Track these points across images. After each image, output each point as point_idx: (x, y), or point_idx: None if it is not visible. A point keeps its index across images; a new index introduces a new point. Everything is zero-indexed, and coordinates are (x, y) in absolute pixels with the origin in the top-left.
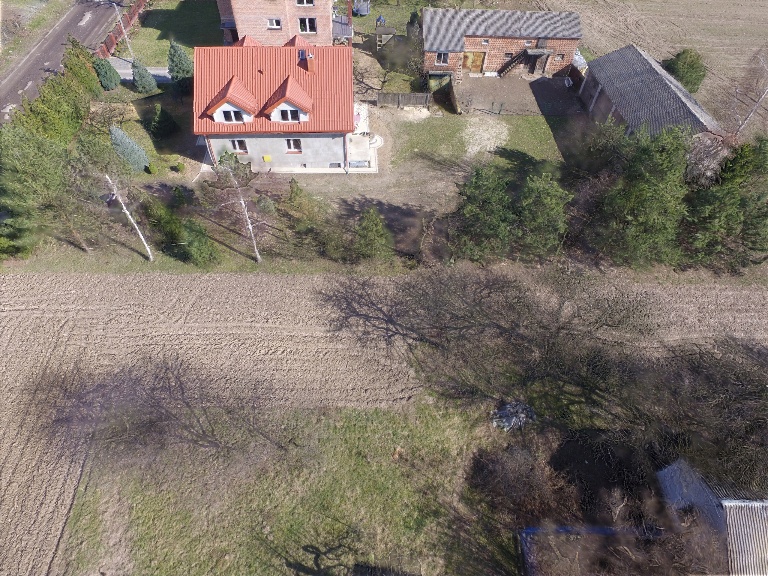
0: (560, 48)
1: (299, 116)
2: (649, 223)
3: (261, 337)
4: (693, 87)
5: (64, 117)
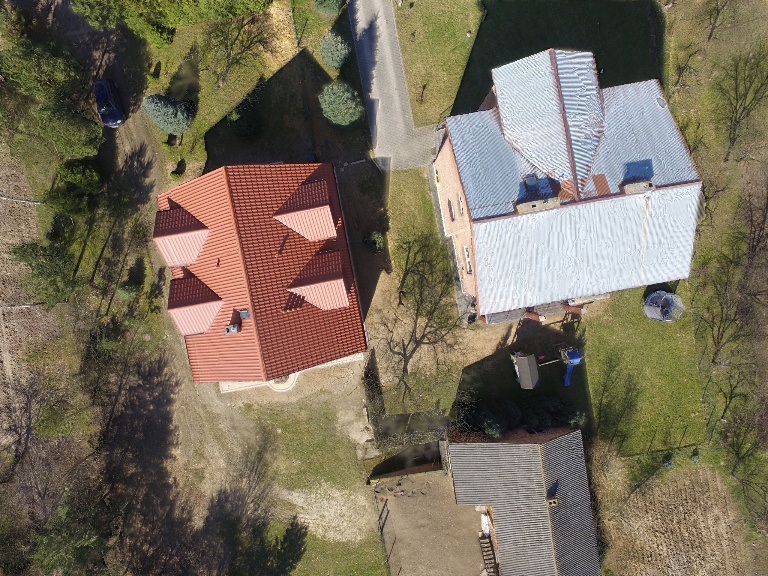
0: None
1: None
2: None
3: None
4: None
5: (204, 6)
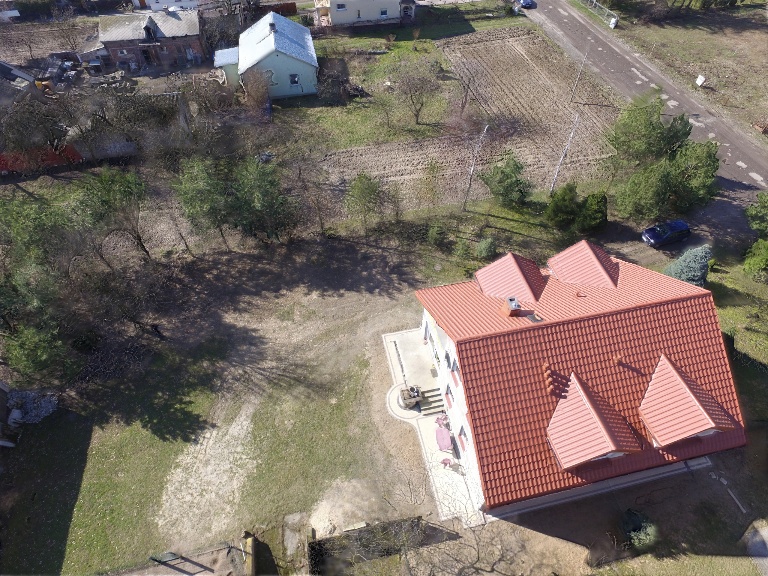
0: None
1: None
2: None
3: None
4: None
5: None
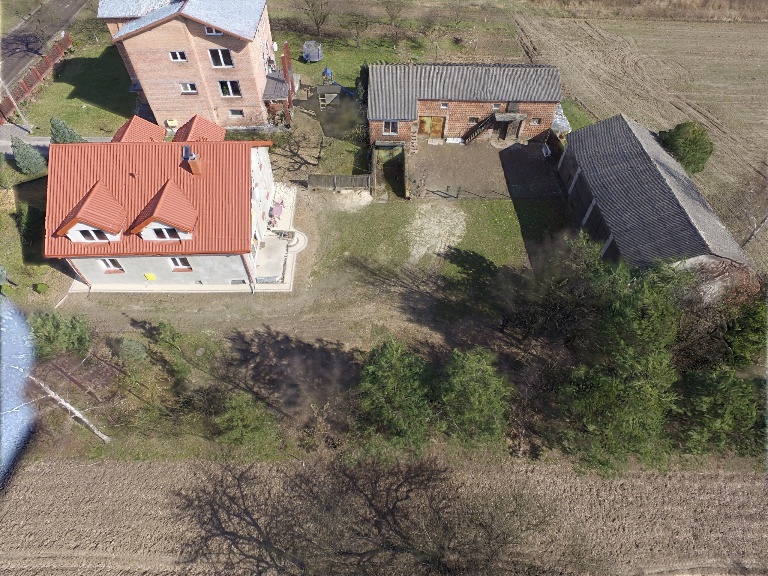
0: (535, 112)
1: (178, 234)
2: (620, 428)
3: (82, 575)
4: (697, 166)
5: None
